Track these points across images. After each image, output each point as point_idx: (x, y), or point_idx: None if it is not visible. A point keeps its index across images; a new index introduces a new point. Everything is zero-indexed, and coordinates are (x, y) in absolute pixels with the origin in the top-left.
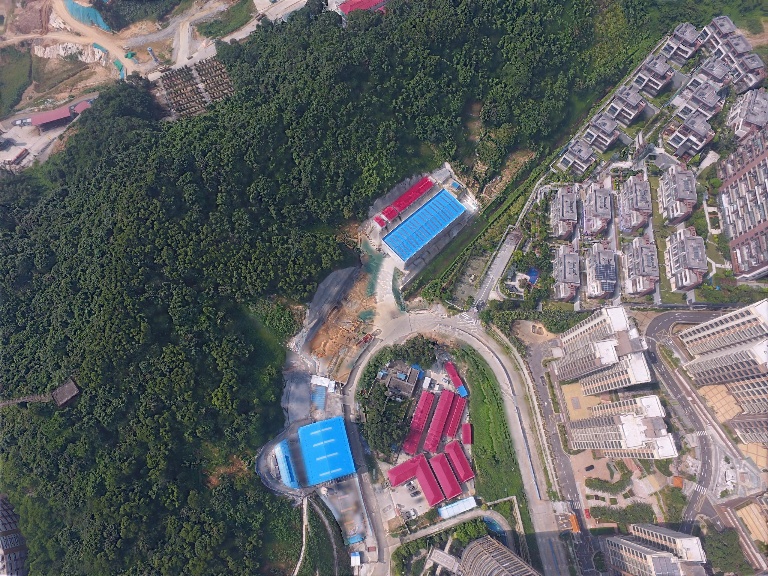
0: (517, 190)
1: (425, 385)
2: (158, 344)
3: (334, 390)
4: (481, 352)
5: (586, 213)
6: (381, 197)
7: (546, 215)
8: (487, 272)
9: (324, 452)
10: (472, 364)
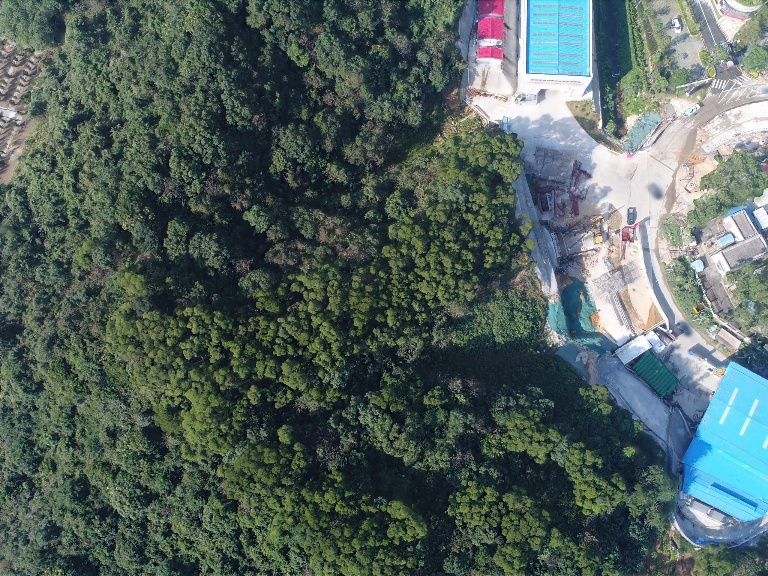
0: None
1: (766, 222)
2: (434, 515)
3: (663, 343)
4: None
5: None
6: (462, 13)
7: None
8: None
9: (764, 428)
10: None
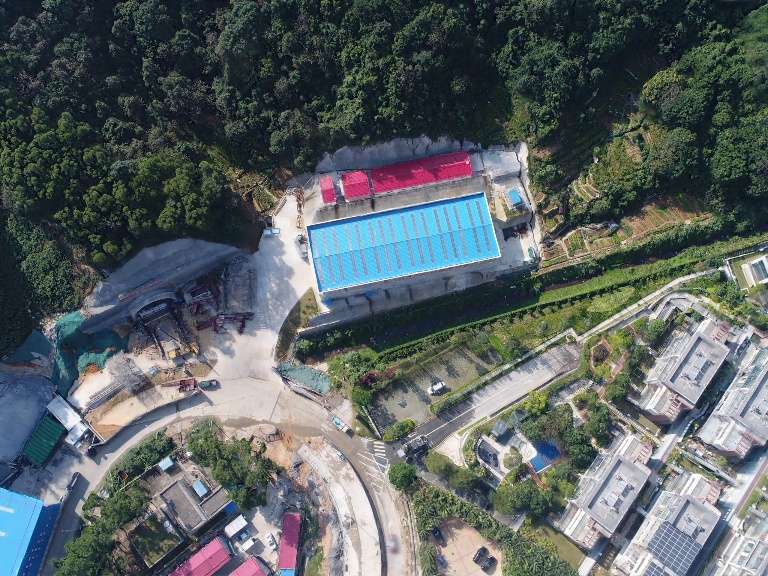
0: (631, 270)
1: (230, 529)
2: None
3: (77, 442)
4: (363, 532)
5: (725, 400)
6: (355, 146)
7: (651, 353)
8: (471, 393)
9: None
10: (332, 544)
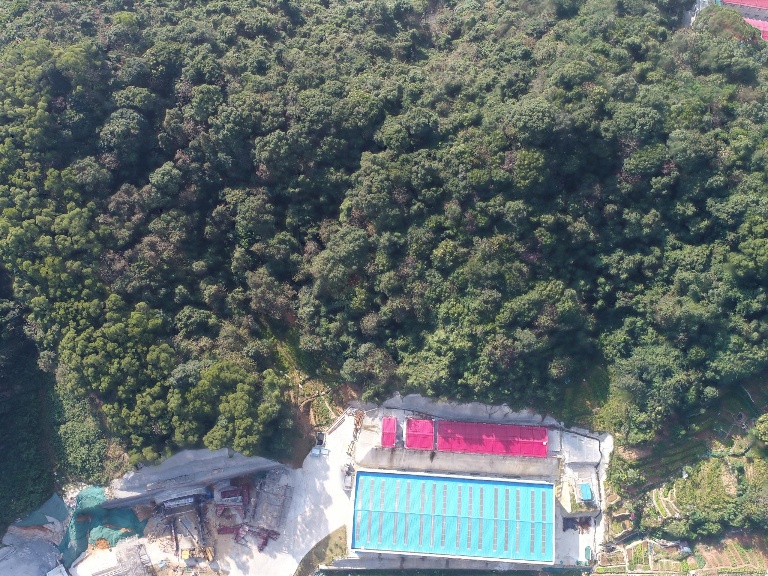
0: None
1: None
2: None
3: None
4: None
5: None
6: (429, 397)
7: None
8: None
9: None
10: None
